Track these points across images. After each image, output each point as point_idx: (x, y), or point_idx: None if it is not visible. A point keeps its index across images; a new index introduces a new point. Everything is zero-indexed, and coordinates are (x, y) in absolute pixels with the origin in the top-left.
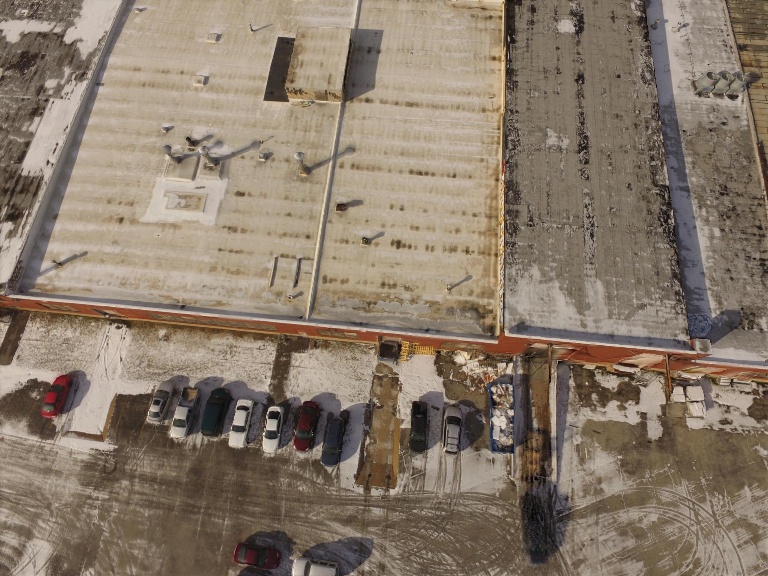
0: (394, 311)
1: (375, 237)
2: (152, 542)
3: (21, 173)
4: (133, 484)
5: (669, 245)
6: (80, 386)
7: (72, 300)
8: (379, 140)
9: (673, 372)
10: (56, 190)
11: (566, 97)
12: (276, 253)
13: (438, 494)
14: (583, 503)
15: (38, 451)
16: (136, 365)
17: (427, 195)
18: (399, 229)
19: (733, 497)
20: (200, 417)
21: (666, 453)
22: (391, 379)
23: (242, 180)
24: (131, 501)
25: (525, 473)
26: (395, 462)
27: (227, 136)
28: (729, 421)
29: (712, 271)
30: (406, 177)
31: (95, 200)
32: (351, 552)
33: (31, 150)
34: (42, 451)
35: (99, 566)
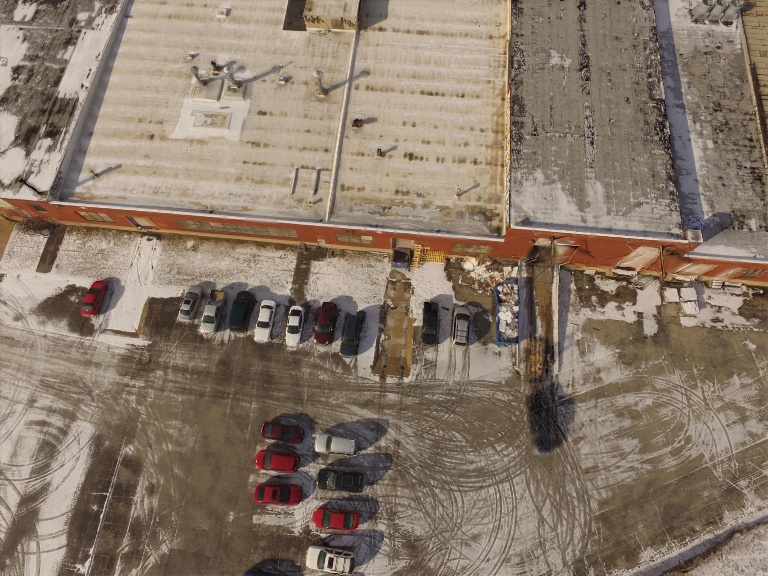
0: (407, 215)
1: (389, 150)
2: (186, 423)
3: (58, 95)
4: (167, 374)
5: (664, 151)
6: (115, 290)
7: (109, 205)
8: (392, 64)
9: (668, 275)
10: (91, 111)
11: (569, 22)
12: (297, 165)
13: (448, 382)
14: (583, 390)
15: (78, 346)
16: (166, 272)
17: (437, 113)
18: (411, 143)
19: (723, 384)
20: (227, 317)
21: (661, 347)
22: (404, 284)
23: (264, 101)
24: (165, 388)
25: (529, 364)
26: (408, 355)
27: (249, 62)
28: (720, 320)
29: (705, 178)
30: (418, 97)
31: (127, 119)
32: (368, 430)
33: (66, 75)
34: (82, 346)
35: (138, 443)
